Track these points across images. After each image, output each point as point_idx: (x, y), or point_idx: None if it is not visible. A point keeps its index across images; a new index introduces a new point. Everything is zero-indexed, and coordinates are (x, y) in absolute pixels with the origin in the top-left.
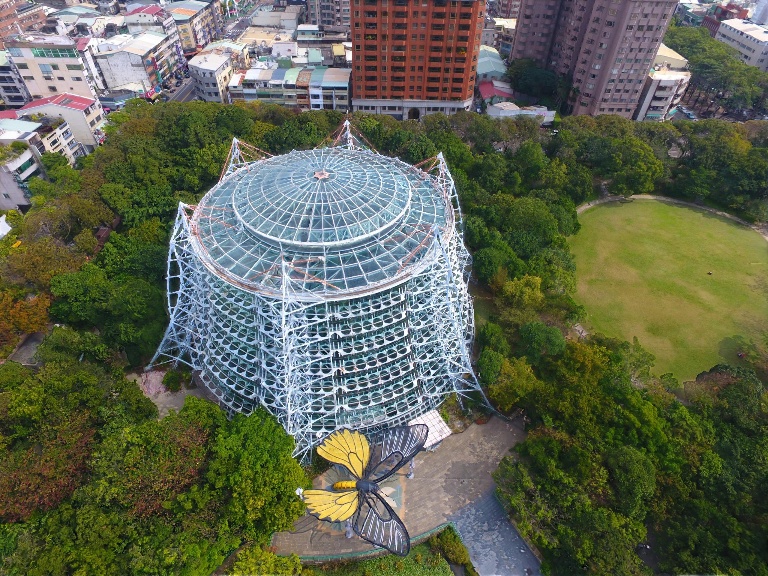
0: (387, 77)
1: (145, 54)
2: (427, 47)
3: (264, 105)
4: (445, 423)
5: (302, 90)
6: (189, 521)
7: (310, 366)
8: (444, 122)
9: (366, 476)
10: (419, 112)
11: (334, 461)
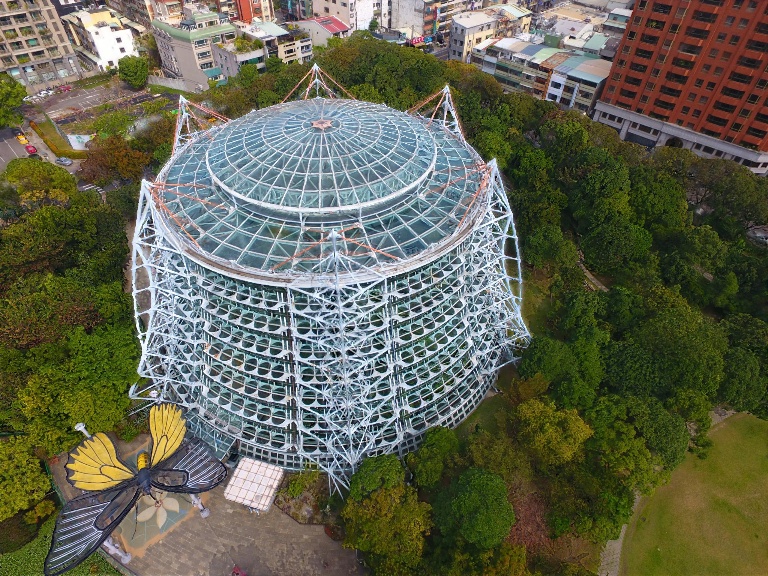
0: (656, 85)
1: (430, 1)
2: (735, 56)
3: (475, 72)
4: (273, 493)
5: (544, 73)
6: (3, 376)
7: (173, 319)
8: (682, 163)
9: (153, 470)
10: (682, 146)
11: (152, 430)
